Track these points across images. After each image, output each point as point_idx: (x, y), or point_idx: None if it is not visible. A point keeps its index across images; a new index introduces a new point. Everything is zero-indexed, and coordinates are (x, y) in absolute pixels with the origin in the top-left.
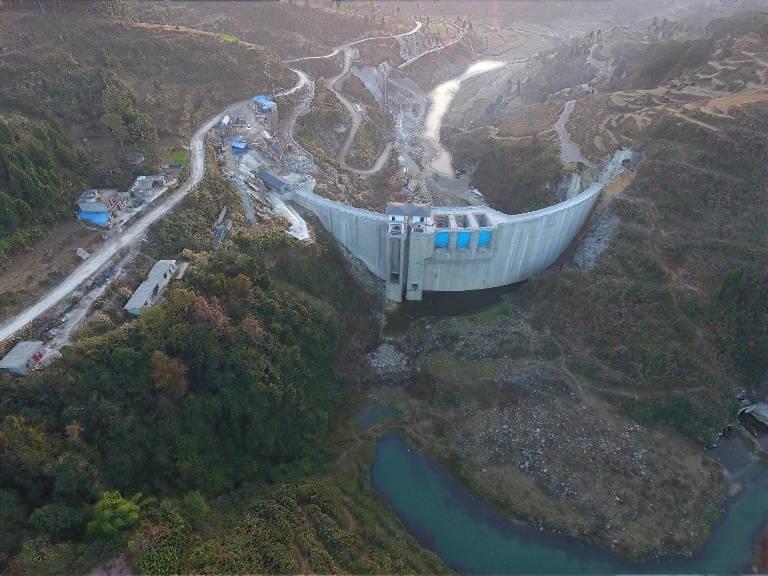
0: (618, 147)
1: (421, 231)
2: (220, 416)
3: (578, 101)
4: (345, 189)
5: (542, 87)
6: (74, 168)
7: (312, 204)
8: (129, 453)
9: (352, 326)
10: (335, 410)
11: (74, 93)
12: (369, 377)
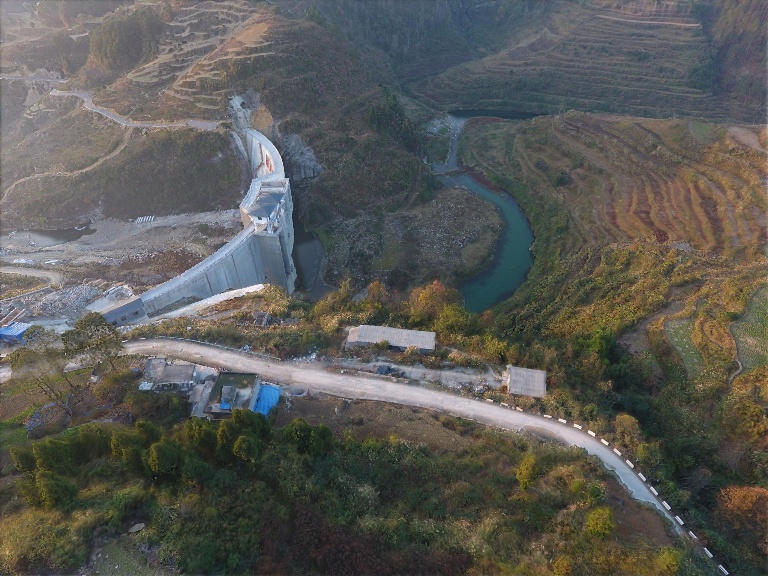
0: (228, 99)
1: None
2: None
3: (98, 101)
4: None
5: None
6: None
7: (181, 289)
8: None
9: None
10: None
11: None
12: None
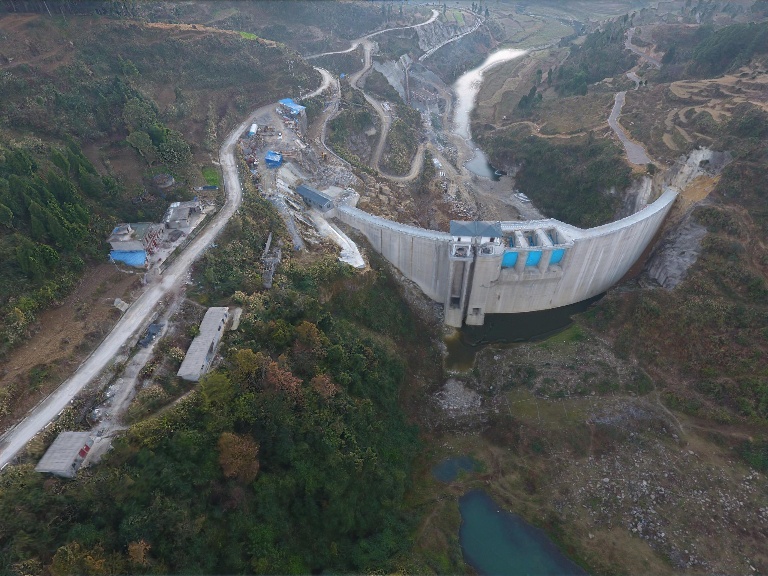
0: (694, 146)
1: (488, 252)
2: (293, 494)
3: (629, 93)
4: (387, 201)
5: (579, 77)
6: (100, 198)
7: (359, 222)
8: (199, 560)
9: (415, 361)
10: (409, 465)
11: (90, 107)
12: (441, 422)
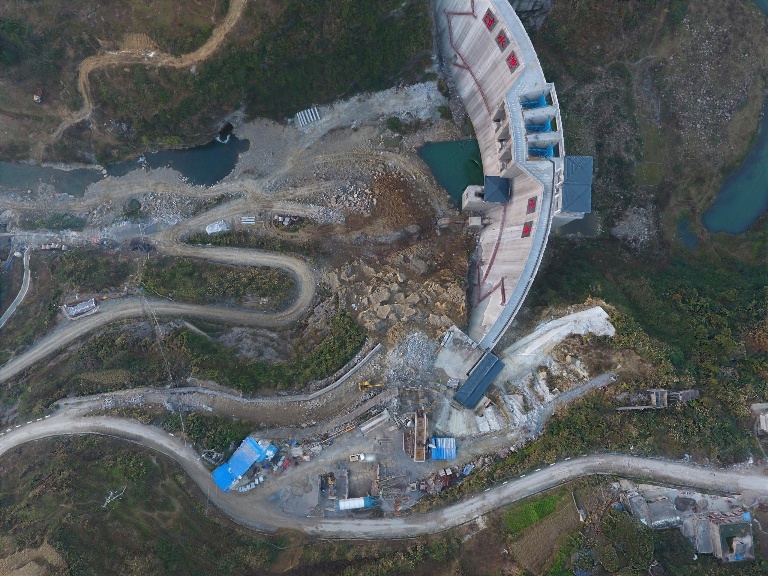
0: None
1: None
2: None
3: None
4: None
5: None
6: None
7: None
8: None
9: (613, 262)
10: None
11: None
12: (659, 242)
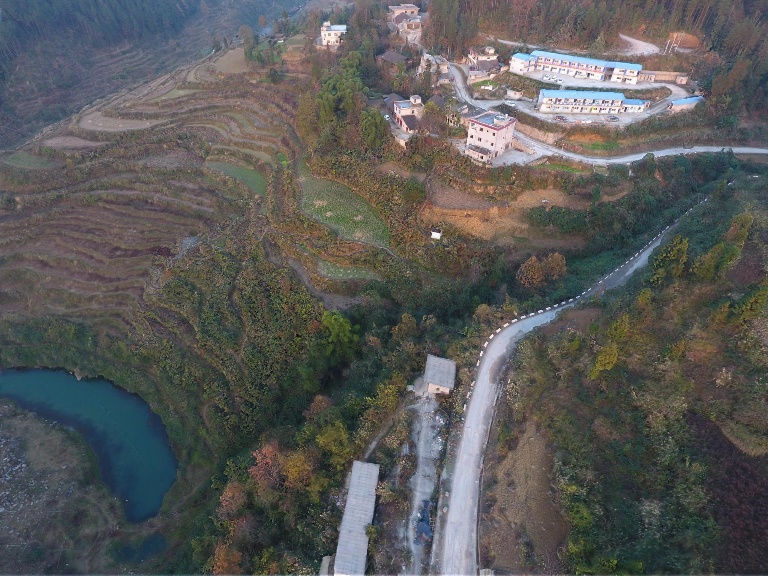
0: None
1: None
2: None
3: None
4: None
5: None
6: None
7: None
8: None
9: None
10: None
11: None
12: None
